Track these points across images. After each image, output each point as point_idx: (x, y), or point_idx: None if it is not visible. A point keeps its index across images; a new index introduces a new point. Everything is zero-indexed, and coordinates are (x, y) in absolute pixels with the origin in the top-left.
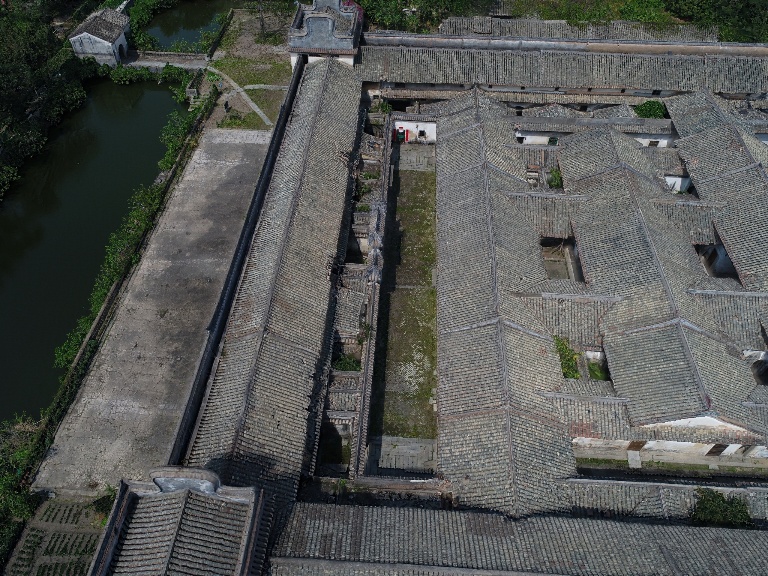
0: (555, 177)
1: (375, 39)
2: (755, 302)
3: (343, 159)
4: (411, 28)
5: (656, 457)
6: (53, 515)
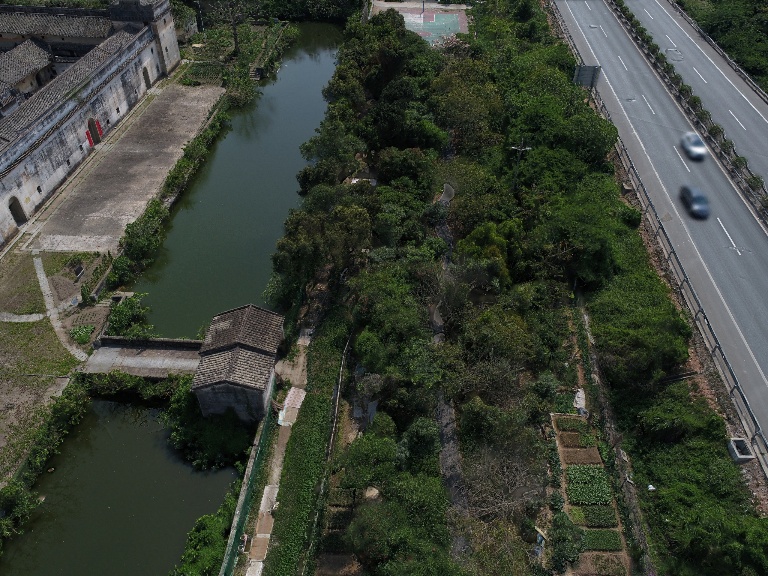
0: None
1: None
2: None
3: None
4: None
5: None
6: (217, 82)
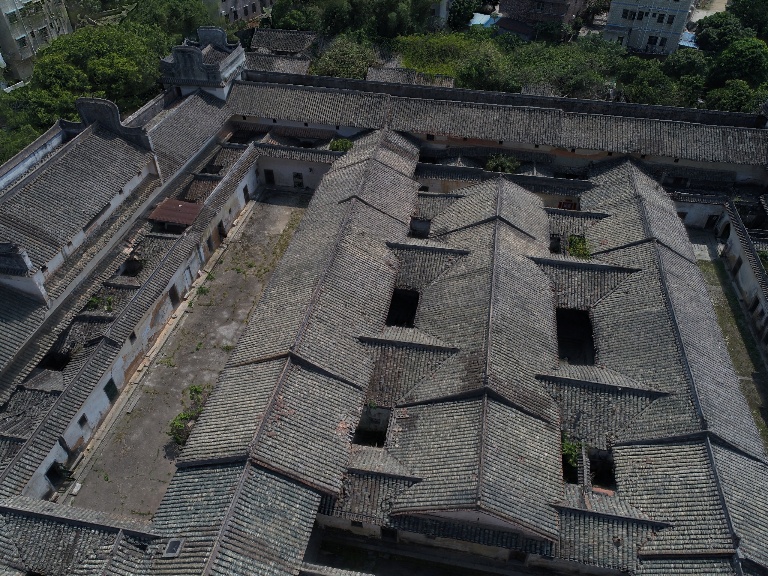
0: None
1: None
2: None
3: None
4: None
5: None
6: None
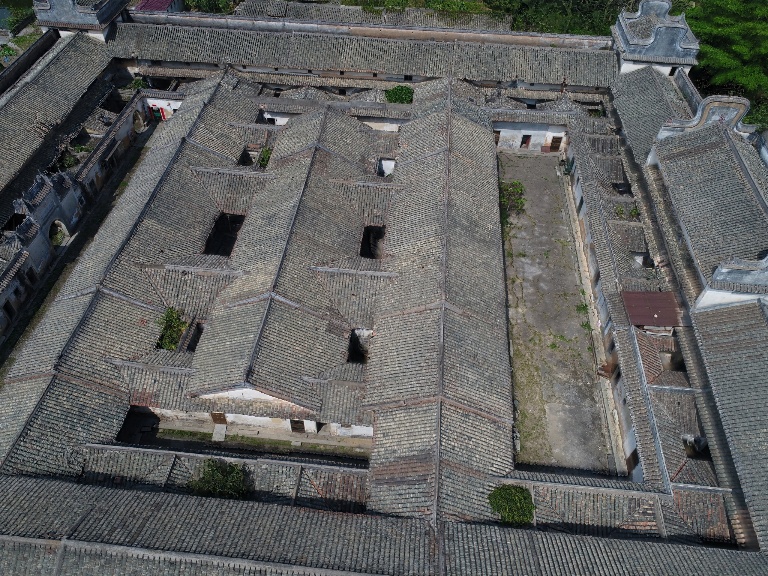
0: (265, 156)
1: (141, 17)
2: (377, 281)
3: (41, 130)
4: (230, 11)
5: (241, 431)
6: None
